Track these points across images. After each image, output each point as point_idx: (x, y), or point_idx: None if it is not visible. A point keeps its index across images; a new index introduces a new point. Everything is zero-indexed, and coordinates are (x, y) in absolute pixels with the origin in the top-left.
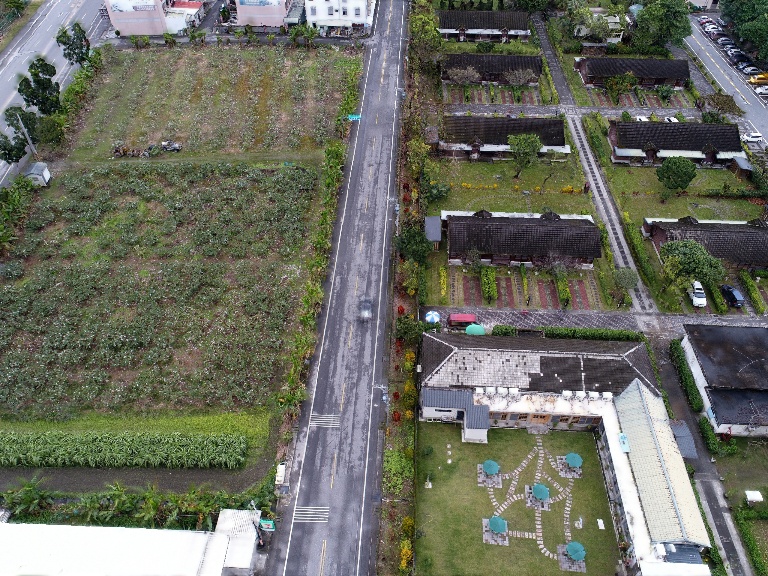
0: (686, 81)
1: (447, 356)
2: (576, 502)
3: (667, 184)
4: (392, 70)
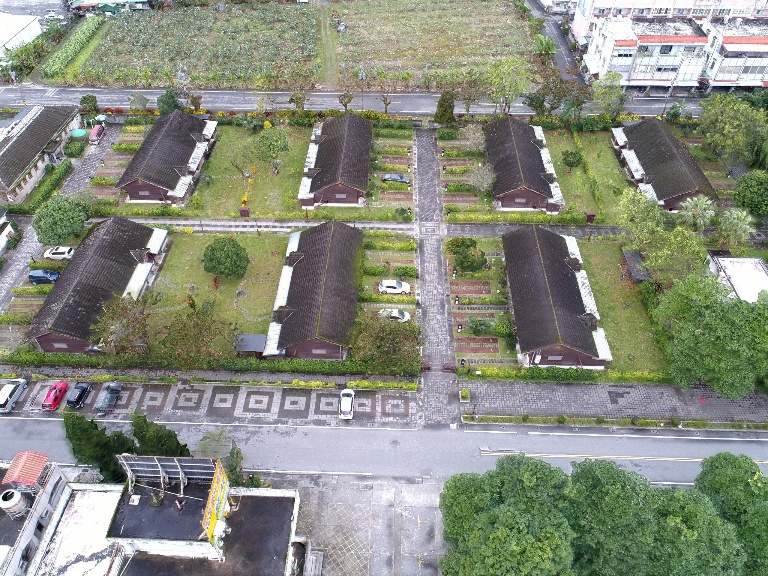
0: None
1: None
2: None
3: None
4: None
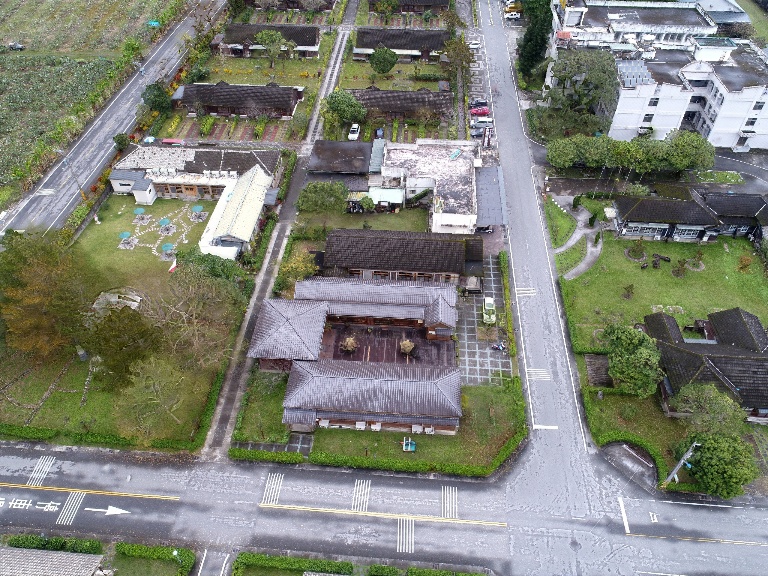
0: (450, 9)
1: (133, 151)
2: (191, 232)
3: (375, 69)
4: (220, 1)
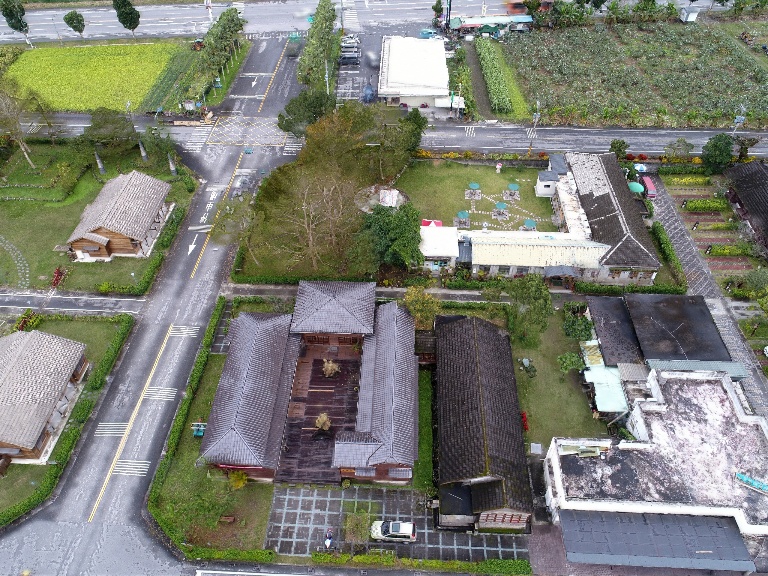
0: None
1: None
2: None
3: None
4: None
